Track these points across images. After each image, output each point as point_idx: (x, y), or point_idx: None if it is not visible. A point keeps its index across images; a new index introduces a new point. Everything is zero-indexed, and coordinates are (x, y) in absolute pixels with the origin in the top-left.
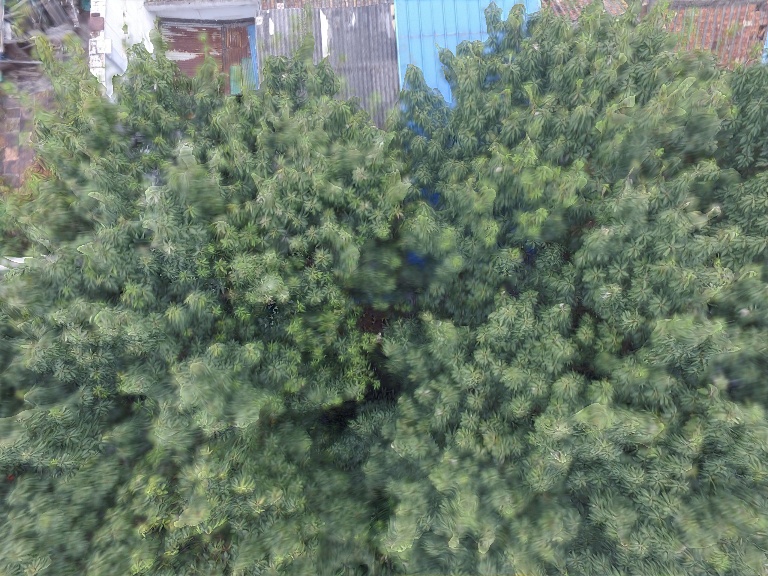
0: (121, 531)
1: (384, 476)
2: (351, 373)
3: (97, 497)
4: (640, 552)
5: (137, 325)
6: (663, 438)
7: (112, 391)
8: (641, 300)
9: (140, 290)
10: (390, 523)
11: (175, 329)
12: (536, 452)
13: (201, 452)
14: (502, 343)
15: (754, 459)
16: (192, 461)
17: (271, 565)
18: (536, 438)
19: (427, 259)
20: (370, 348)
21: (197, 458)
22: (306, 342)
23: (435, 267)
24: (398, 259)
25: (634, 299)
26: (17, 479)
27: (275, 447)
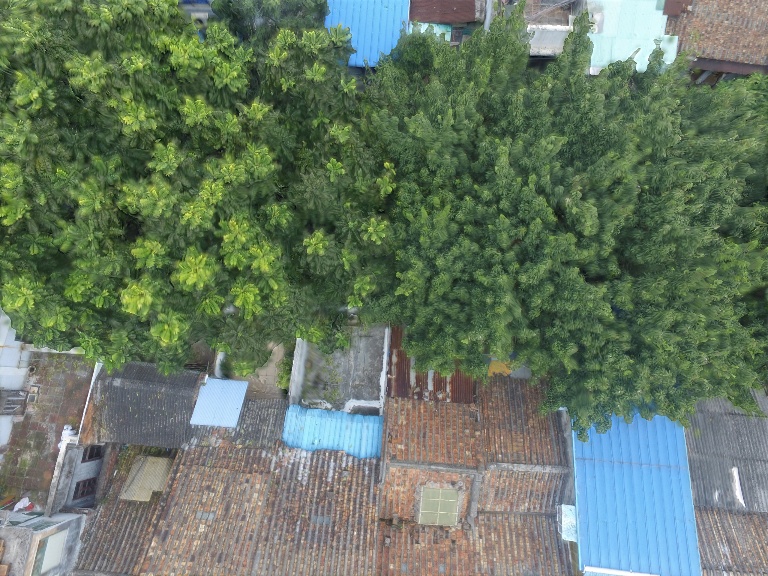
0: None
1: None
2: None
3: None
4: None
5: None
6: None
7: None
8: None
9: None
10: None
11: None
12: None
13: None
14: None
15: None
16: None
17: None
18: None
19: None
20: None
21: None
22: None
23: None
24: None
25: None
26: None
27: None
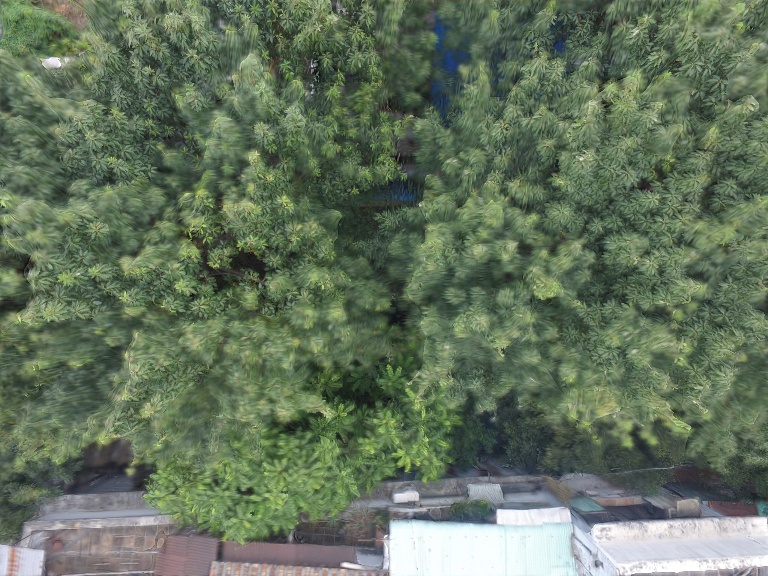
0: (170, 230)
1: (407, 256)
2: (381, 158)
3: (145, 215)
4: (651, 270)
5: (201, 16)
6: (679, 162)
7: (161, 132)
8: (667, 37)
9: (200, 6)
10: (414, 275)
11: (228, 59)
12: (558, 192)
13: (250, 154)
14: (531, 102)
15: (765, 145)
16: (237, 182)
17: (303, 293)
18: (559, 176)
19: (463, 34)
20: (401, 134)
21: (244, 167)
22: (341, 122)
23: (470, 44)
24: (435, 34)
25: (660, 38)
26: (75, 181)
27: (308, 208)
